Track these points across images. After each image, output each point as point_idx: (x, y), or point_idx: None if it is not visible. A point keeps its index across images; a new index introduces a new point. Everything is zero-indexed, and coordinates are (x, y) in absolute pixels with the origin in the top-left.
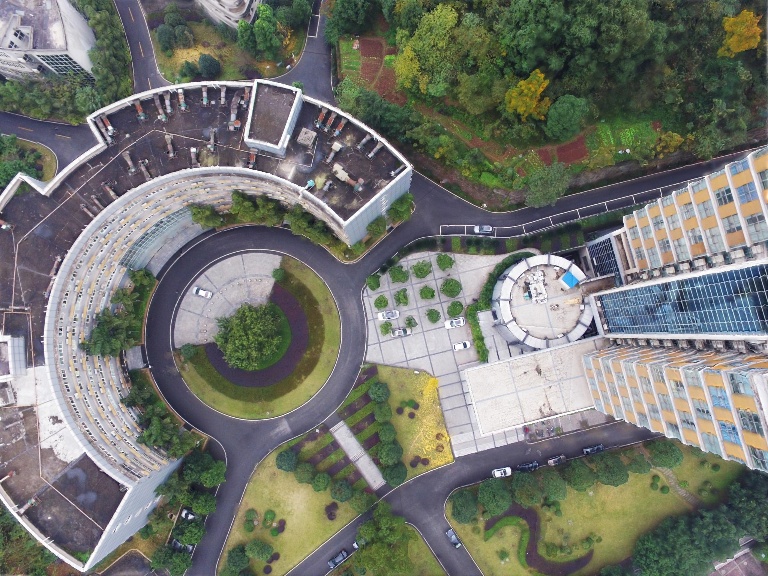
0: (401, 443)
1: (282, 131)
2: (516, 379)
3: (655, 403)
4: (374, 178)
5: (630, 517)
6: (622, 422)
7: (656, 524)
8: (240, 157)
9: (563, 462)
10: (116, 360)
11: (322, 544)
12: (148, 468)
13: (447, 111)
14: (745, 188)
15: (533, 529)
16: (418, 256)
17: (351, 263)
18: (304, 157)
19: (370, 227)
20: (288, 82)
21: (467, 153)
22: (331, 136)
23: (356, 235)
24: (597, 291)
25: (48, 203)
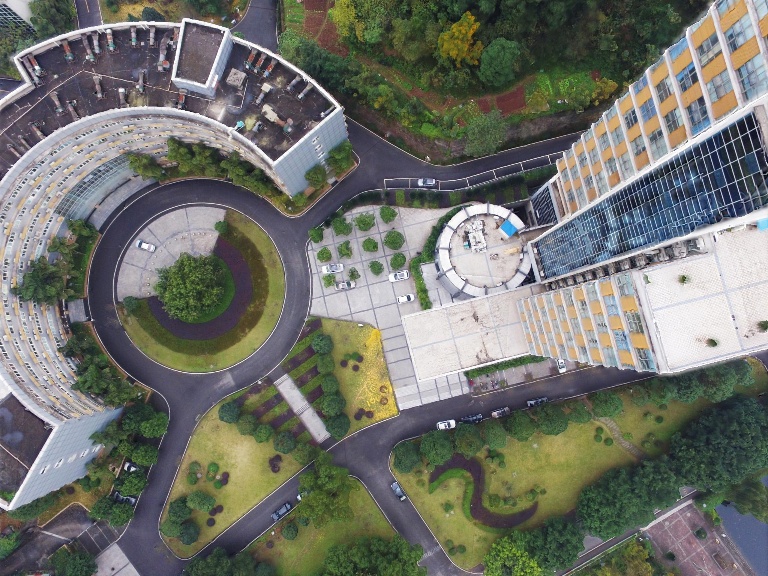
0: (345, 396)
1: (210, 70)
2: (453, 326)
3: (569, 329)
4: (304, 119)
5: (574, 469)
6: (566, 375)
7: (600, 476)
8: (170, 98)
9: (507, 414)
10: (55, 311)
11: (266, 497)
12: (80, 412)
13: (387, 61)
14: (646, 105)
15: (477, 481)
16: (363, 210)
17: (296, 217)
18: (234, 98)
19: (308, 175)
20: None
21: (408, 103)
22: (261, 77)
23: (294, 183)
24: None
25: None
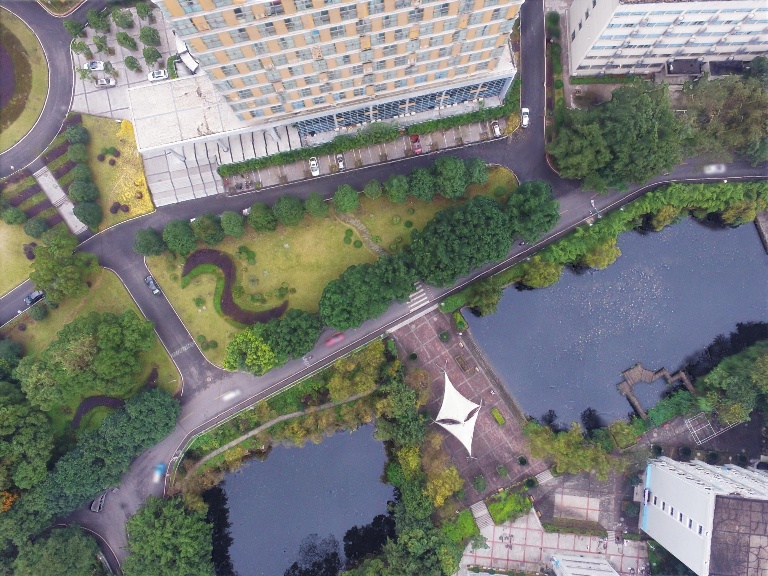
0: (102, 189)
1: None
2: (177, 99)
3: None
4: None
5: (324, 270)
6: (321, 179)
7: None
8: None
9: None
10: None
11: (22, 283)
12: None
13: None
14: None
15: (228, 277)
16: None
17: (62, 17)
18: None
19: None
20: None
21: None
22: None
23: None
24: None
25: None
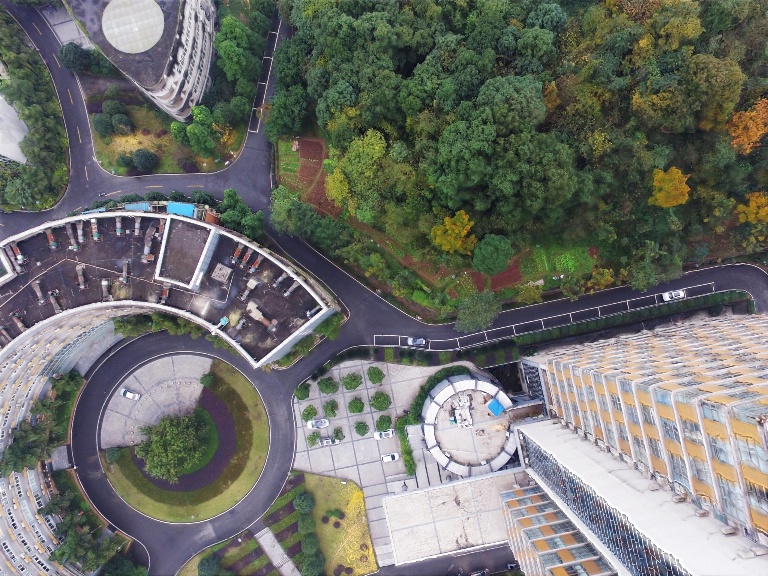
0: (325, 552)
1: (194, 270)
2: (434, 509)
3: None
4: (290, 316)
5: None
6: None
7: None
8: (153, 290)
9: None
10: (37, 465)
11: None
12: None
13: (380, 228)
14: (631, 408)
15: None
16: (351, 364)
17: (283, 369)
18: (219, 292)
19: (294, 348)
20: (227, 178)
21: (399, 271)
22: (247, 271)
23: (280, 356)
24: (524, 417)
25: None
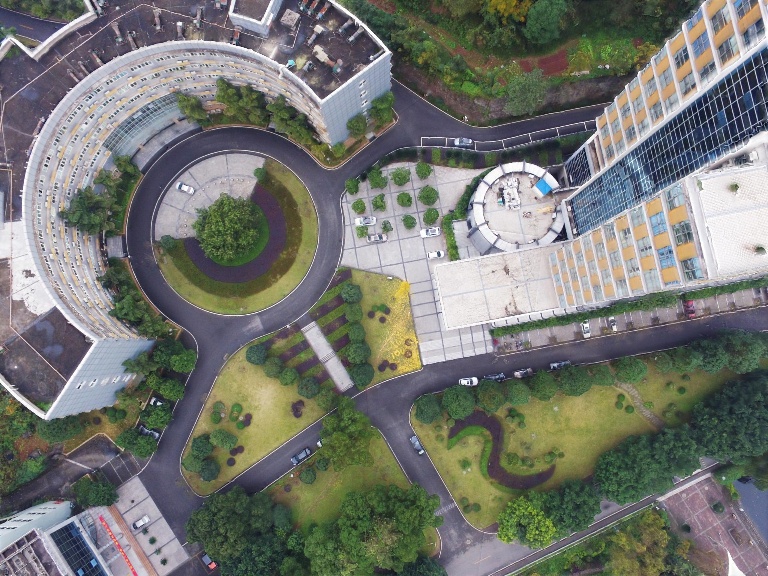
0: (370, 347)
1: (266, 8)
2: (484, 277)
3: (607, 265)
4: (353, 62)
5: (593, 435)
6: (590, 340)
7: (619, 443)
8: (225, 35)
9: (529, 375)
10: (96, 243)
11: (287, 441)
12: (117, 335)
13: (433, 19)
14: (699, 40)
15: (496, 440)
16: (398, 166)
17: (332, 169)
18: (287, 38)
19: (350, 123)
20: None
21: None
22: (314, 20)
23: (336, 130)
24: None
25: (37, 67)
